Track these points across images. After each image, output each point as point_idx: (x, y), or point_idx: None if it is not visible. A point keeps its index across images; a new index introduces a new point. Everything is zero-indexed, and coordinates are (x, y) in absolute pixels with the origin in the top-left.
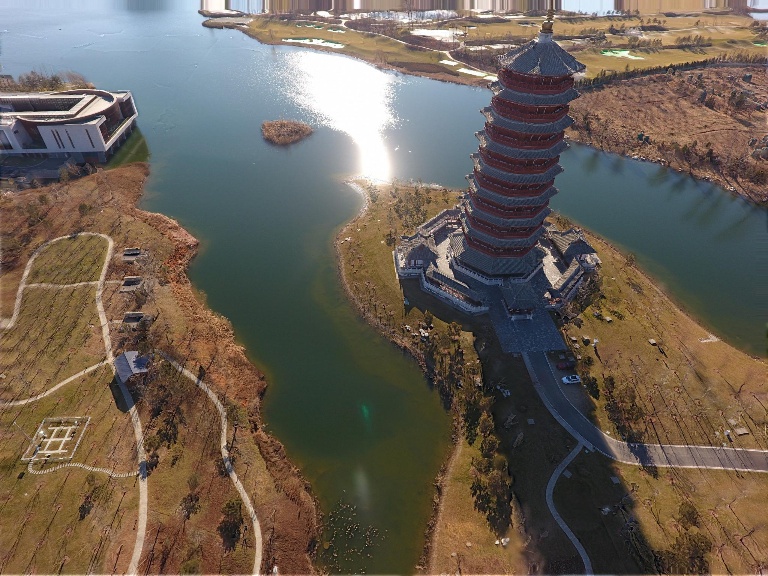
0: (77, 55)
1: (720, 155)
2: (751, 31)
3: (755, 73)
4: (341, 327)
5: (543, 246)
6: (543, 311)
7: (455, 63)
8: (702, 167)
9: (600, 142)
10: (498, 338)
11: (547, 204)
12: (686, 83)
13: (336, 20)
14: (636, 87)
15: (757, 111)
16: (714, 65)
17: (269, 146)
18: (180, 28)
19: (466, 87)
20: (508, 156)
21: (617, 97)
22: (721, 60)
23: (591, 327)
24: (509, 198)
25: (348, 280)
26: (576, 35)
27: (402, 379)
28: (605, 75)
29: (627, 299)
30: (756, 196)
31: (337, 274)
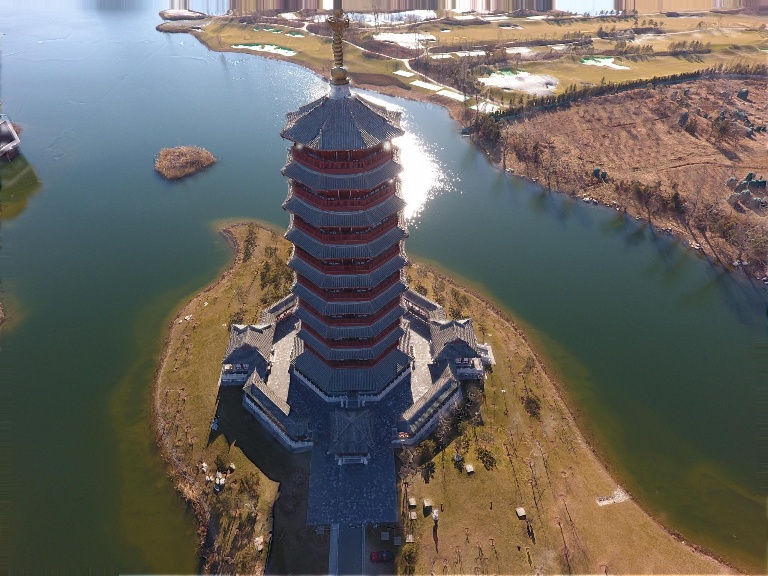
0: (3, 65)
1: (689, 199)
2: (760, 34)
3: (754, 87)
4: (125, 458)
5: (423, 337)
6: (387, 449)
7: (411, 74)
8: (665, 215)
9: (548, 178)
10: (308, 497)
11: (397, 303)
12: (669, 100)
13: (298, 23)
14: (608, 105)
15: (747, 138)
16: (708, 77)
17: (156, 181)
18: (129, 33)
19: (416, 103)
20: (310, 253)
21: (583, 118)
22: (716, 71)
23: (442, 482)
24: (329, 302)
25: (162, 382)
26: (559, 39)
27: (168, 555)
28: (576, 90)
29: (512, 427)
30: (726, 258)
31: (154, 371)
